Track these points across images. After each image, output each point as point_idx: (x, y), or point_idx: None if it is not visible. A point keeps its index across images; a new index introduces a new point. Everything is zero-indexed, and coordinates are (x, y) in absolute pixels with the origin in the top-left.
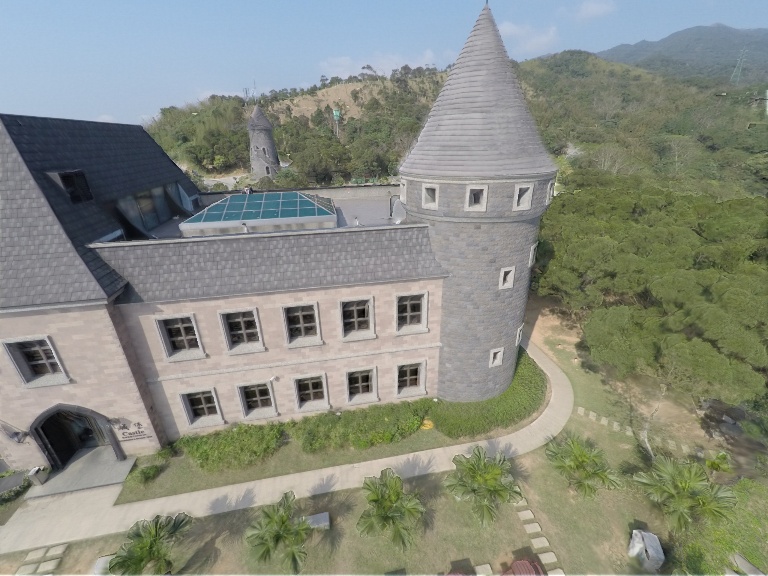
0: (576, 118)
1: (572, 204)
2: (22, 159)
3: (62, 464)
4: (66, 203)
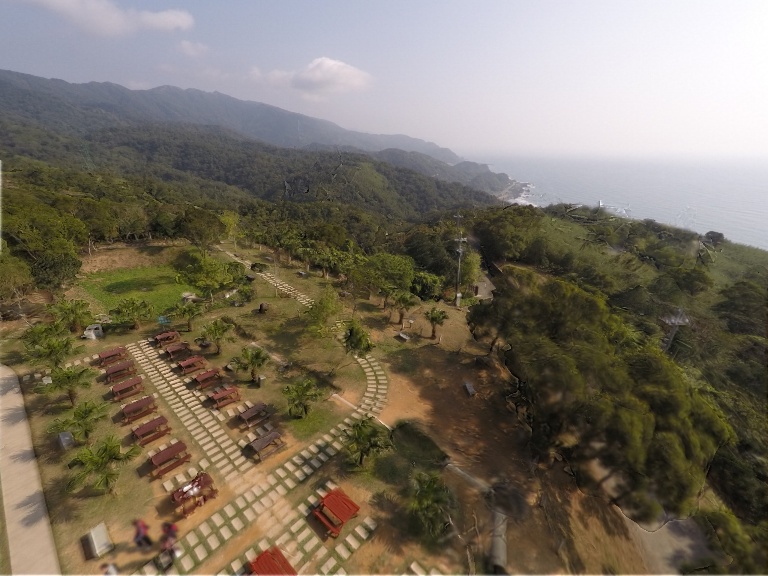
0: None
1: None
2: None
3: None
4: None
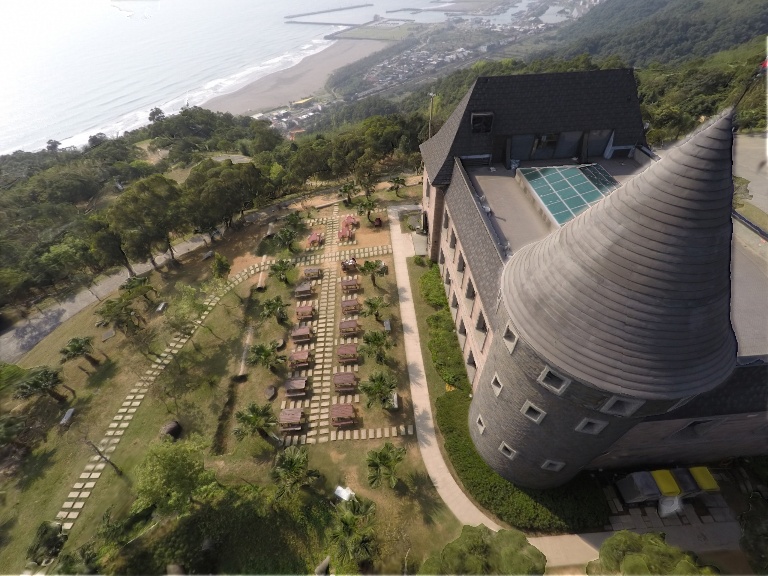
0: None
1: None
2: (468, 104)
3: (424, 233)
4: (469, 132)
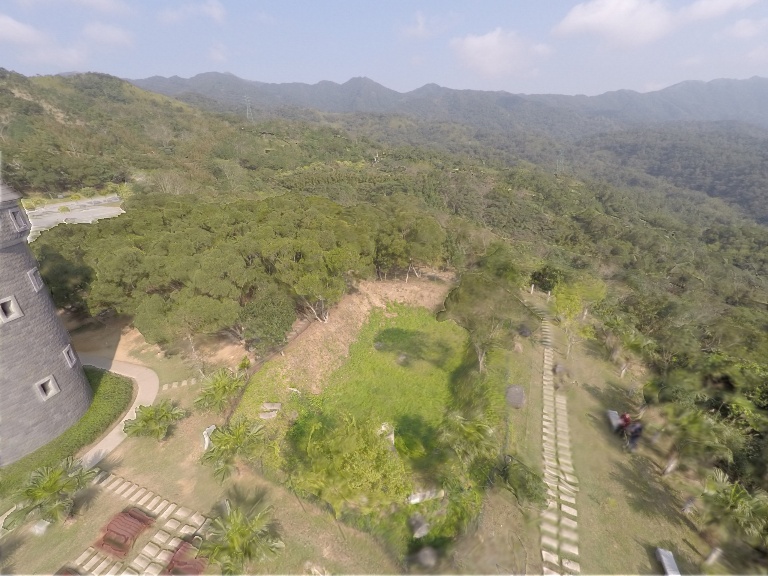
0: (128, 145)
1: (108, 228)
2: None
3: None
4: None
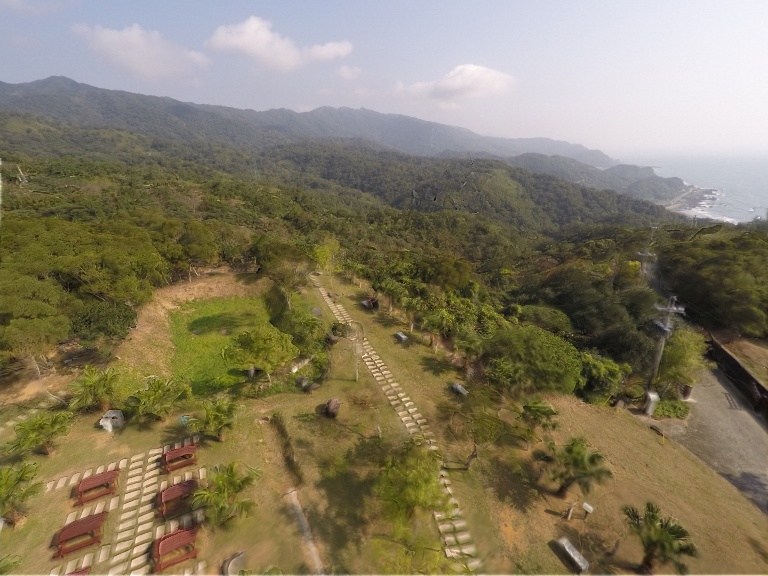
0: None
1: None
2: None
3: None
4: None
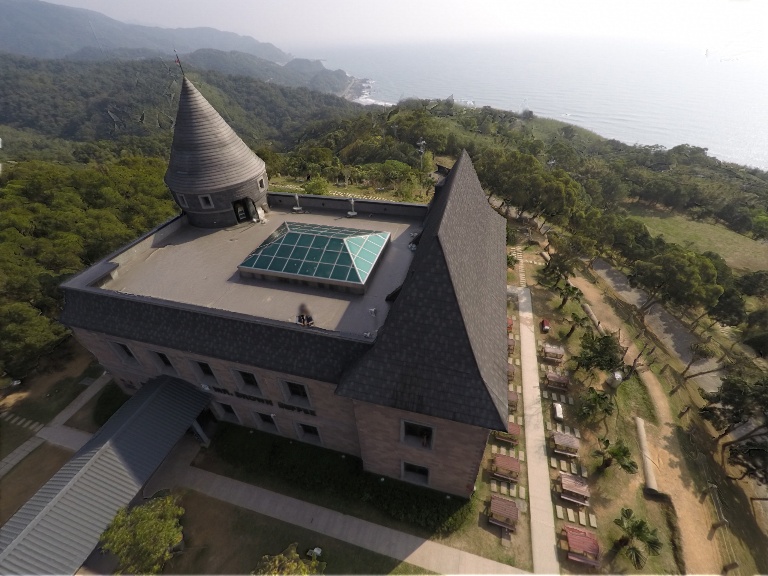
0: None
1: None
2: None
3: None
4: None
